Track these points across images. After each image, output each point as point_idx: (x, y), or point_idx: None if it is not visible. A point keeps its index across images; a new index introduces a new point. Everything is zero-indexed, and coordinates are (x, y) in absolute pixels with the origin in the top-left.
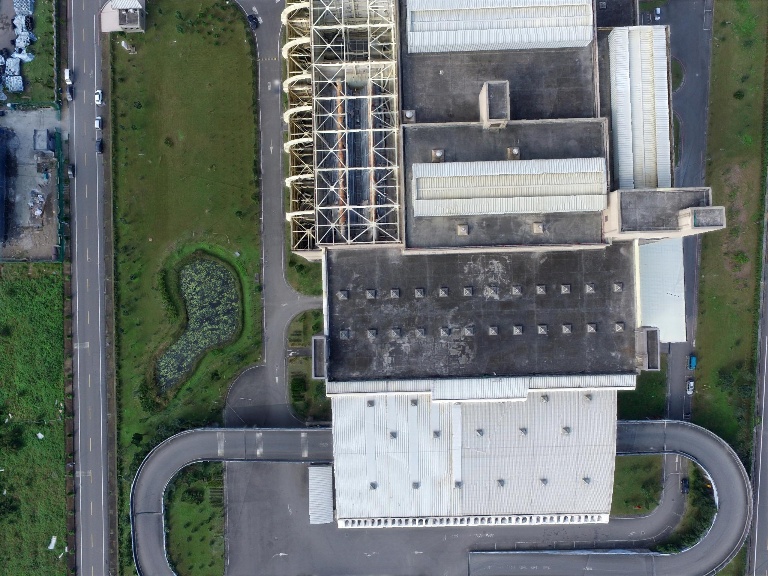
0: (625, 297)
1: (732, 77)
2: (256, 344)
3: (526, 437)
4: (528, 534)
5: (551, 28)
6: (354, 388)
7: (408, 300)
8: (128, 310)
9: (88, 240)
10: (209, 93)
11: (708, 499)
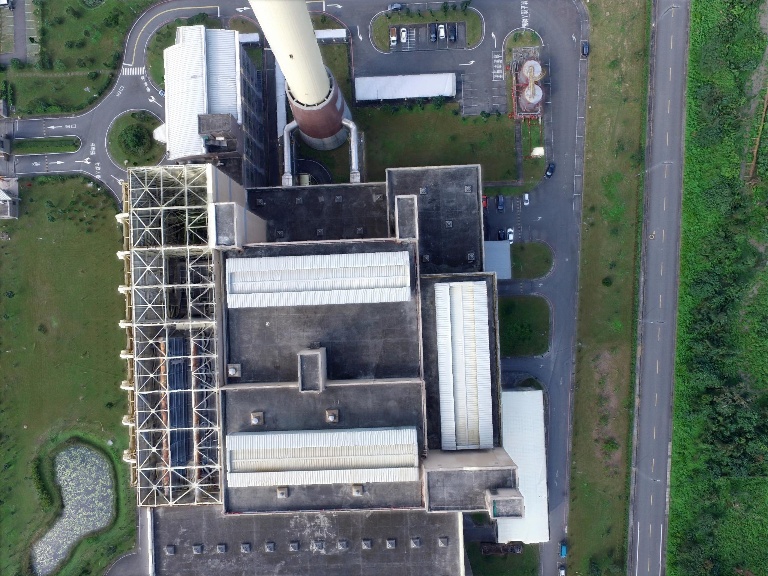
0: (451, 551)
1: (601, 262)
2: (130, 532)
3: None
4: None
5: (369, 290)
6: None
7: (235, 555)
8: (4, 497)
9: None
10: (82, 279)
11: None
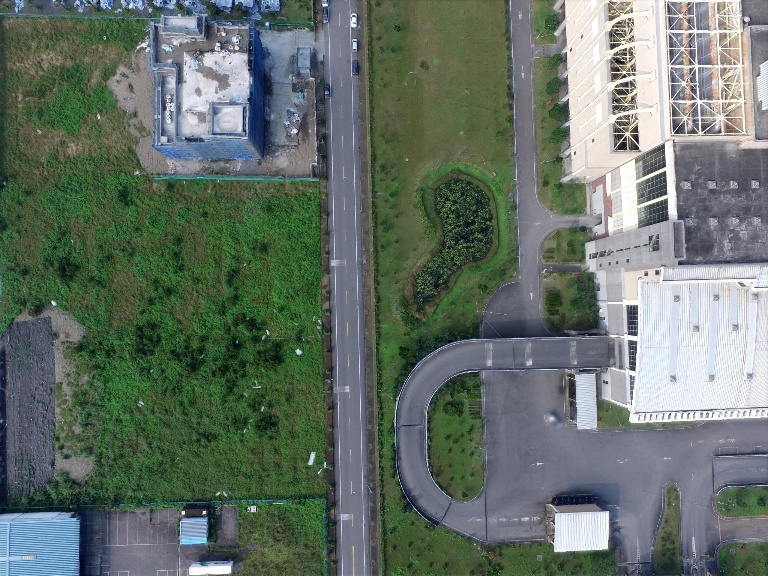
0: None
1: None
2: None
3: None
4: (766, 438)
5: None
6: (688, 275)
7: (745, 191)
8: None
9: (344, 159)
10: (463, 20)
11: None
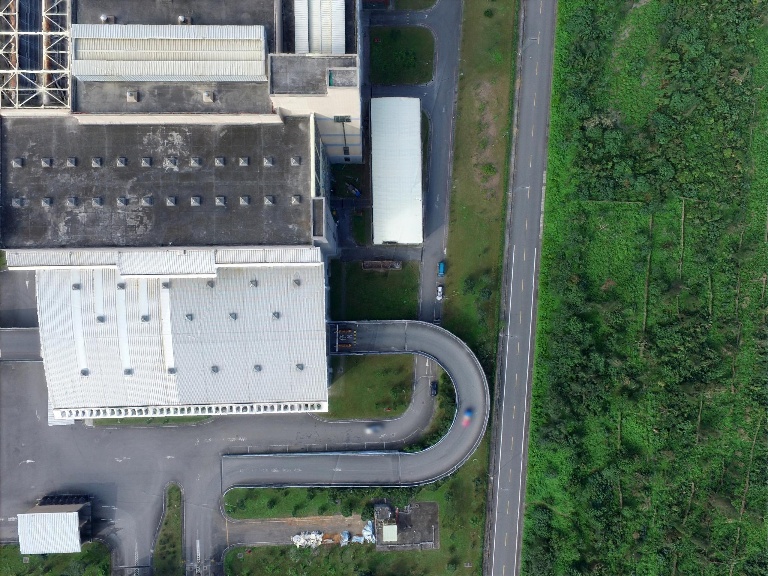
0: (303, 171)
1: None
2: None
3: (237, 322)
4: (281, 437)
5: None
6: (36, 261)
7: (85, 170)
8: None
9: None
10: None
11: (449, 398)
